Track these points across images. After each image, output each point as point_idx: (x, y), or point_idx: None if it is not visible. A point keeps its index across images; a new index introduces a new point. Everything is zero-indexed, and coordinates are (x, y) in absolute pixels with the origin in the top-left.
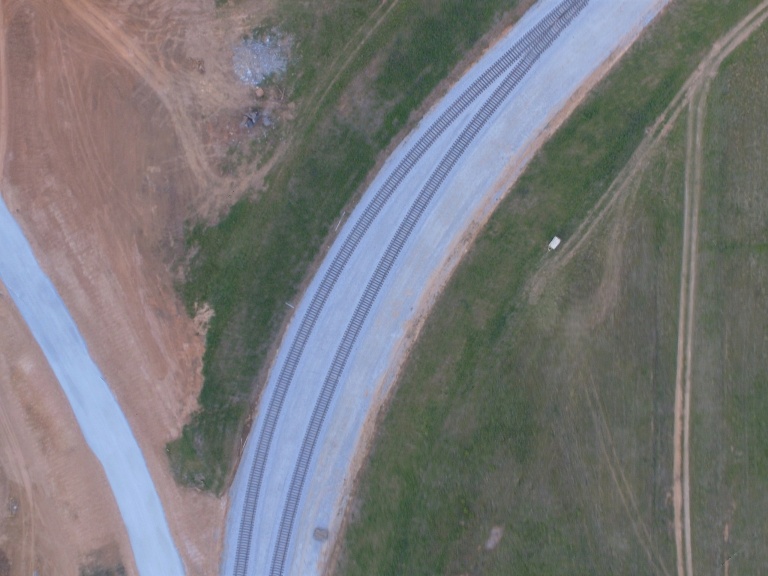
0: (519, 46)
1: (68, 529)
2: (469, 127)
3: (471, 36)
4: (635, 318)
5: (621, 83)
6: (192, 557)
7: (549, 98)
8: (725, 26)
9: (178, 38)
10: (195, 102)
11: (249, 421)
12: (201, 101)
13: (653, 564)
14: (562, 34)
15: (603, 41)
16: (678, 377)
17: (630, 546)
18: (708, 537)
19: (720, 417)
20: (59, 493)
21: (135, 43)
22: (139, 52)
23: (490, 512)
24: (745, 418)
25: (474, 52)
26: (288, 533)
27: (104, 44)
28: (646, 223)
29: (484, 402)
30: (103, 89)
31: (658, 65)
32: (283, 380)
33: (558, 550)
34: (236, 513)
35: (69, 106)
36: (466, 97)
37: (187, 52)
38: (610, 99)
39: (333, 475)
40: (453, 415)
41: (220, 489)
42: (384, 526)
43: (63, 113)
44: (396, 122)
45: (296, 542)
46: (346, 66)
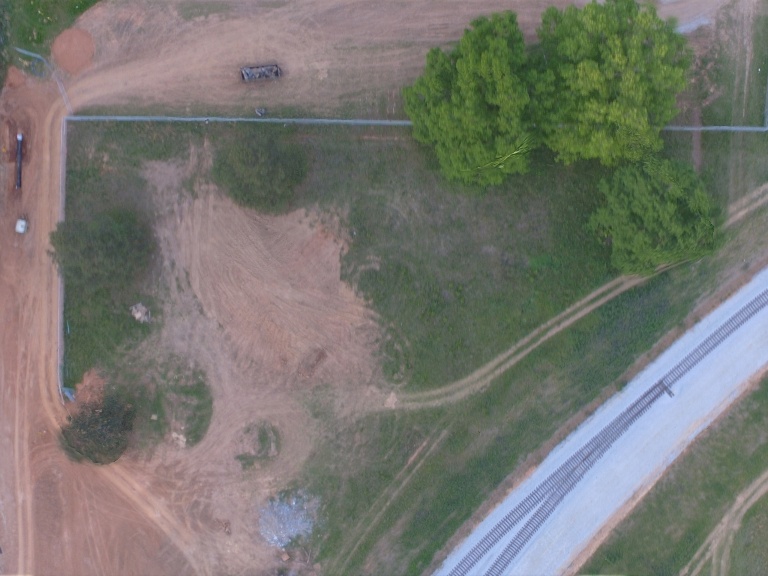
0: (543, 487)
1: None
2: (493, 568)
3: (495, 480)
4: None
5: (644, 527)
6: None
7: (572, 538)
8: (748, 479)
9: (204, 499)
10: (221, 563)
11: None
12: (227, 561)
13: None
14: (586, 476)
15: (626, 481)
16: None
17: None
18: None
19: None
20: None
21: (162, 504)
22: (166, 512)
23: None
24: None
25: (498, 492)
26: None
27: (131, 505)
28: None
29: None
30: (129, 549)
31: (681, 514)
32: None
33: None
34: None
35: (95, 565)
36: (490, 538)
37: (213, 514)
38: (633, 544)
39: None
40: None
41: None
42: None
43: (89, 572)
44: (420, 564)
45: None
46: (372, 528)
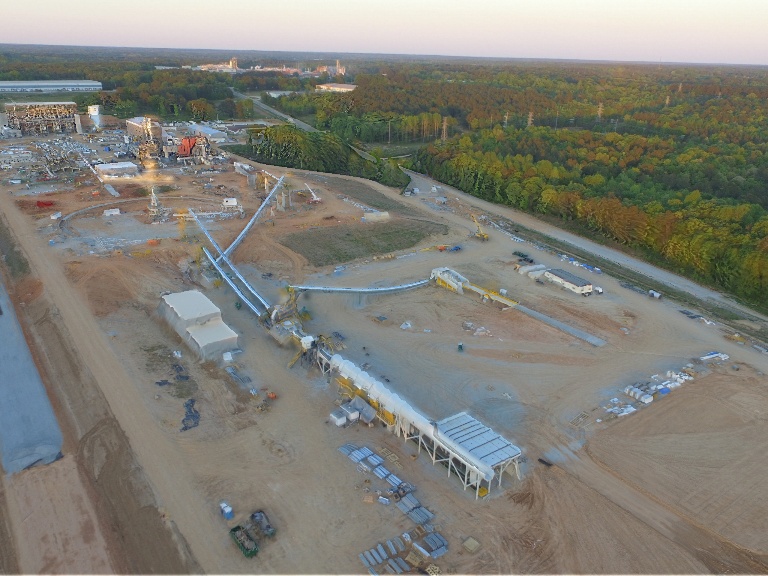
0: None
1: None
2: None
3: None
4: (5, 101)
5: None
6: None
7: None
8: None
9: None
10: None
11: None
12: None
13: None
14: None
15: None
16: None
17: None
18: None
19: None
20: None
21: None
22: None
23: None
24: None
25: None
26: None
27: None
28: (5, 100)
29: None
30: None
31: None
32: None
33: None
34: None
35: None
36: None
37: None
38: None
39: None
40: None
41: None
42: None
43: None
44: None
45: None
46: None
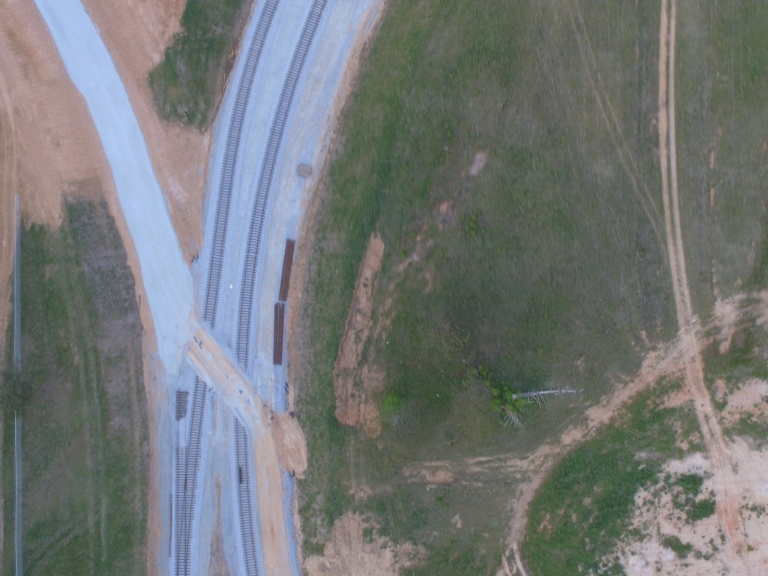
0: None
1: (50, 155)
2: None
3: None
4: None
5: None
6: (175, 194)
7: None
8: None
9: None
10: None
11: (232, 57)
12: None
13: (638, 192)
14: None
15: None
16: (663, 1)
17: (615, 172)
18: (694, 164)
19: (706, 43)
20: (41, 119)
21: None
22: None
23: (474, 137)
24: (731, 43)
25: None
26: (271, 168)
27: None
28: None
29: (468, 25)
30: None
31: None
32: (266, 14)
33: (542, 176)
34: (219, 148)
35: None
36: None
37: None
38: None
39: (317, 111)
40: (437, 39)
41: (203, 124)
42: (367, 153)
43: None
44: None
45: (279, 178)
46: None
